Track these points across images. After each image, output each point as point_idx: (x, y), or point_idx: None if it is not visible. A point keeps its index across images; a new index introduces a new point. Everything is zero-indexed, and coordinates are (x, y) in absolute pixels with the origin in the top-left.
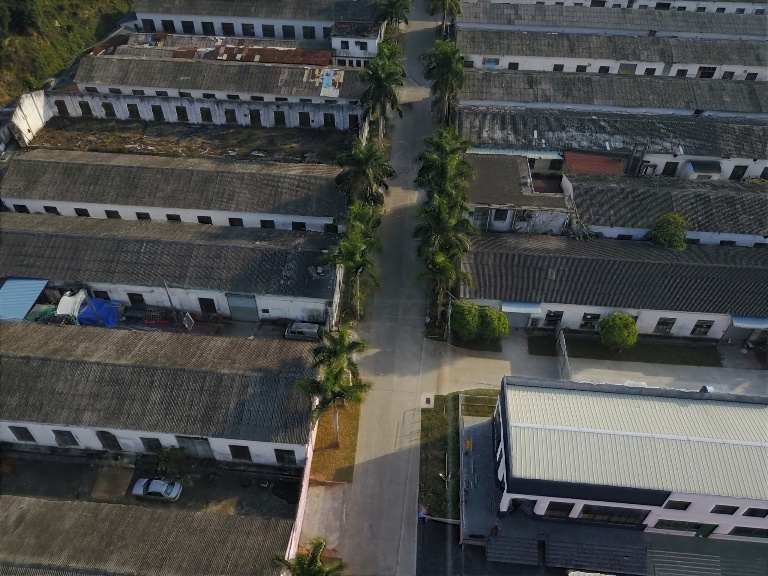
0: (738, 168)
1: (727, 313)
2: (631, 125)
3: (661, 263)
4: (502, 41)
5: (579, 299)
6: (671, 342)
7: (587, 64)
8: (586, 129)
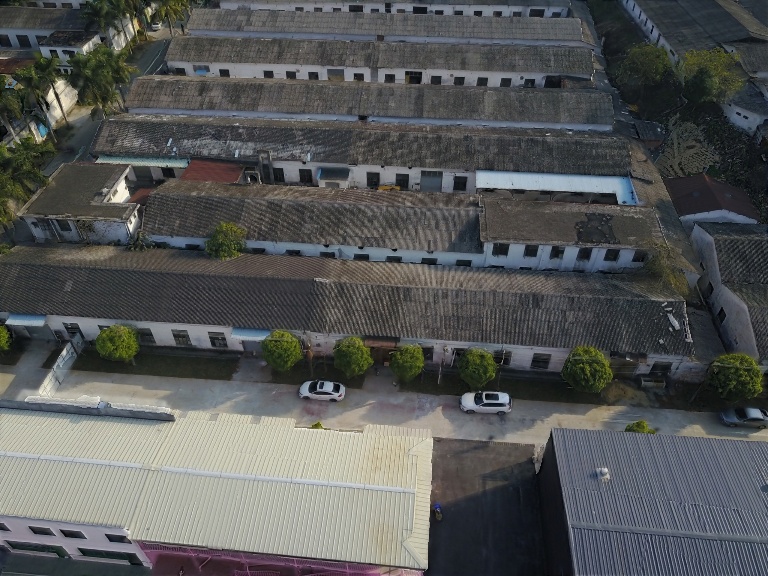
0: (371, 175)
1: (226, 325)
2: (268, 132)
3: (182, 274)
4: (213, 48)
5: (84, 311)
6: (197, 354)
7: (295, 70)
8: (222, 136)
